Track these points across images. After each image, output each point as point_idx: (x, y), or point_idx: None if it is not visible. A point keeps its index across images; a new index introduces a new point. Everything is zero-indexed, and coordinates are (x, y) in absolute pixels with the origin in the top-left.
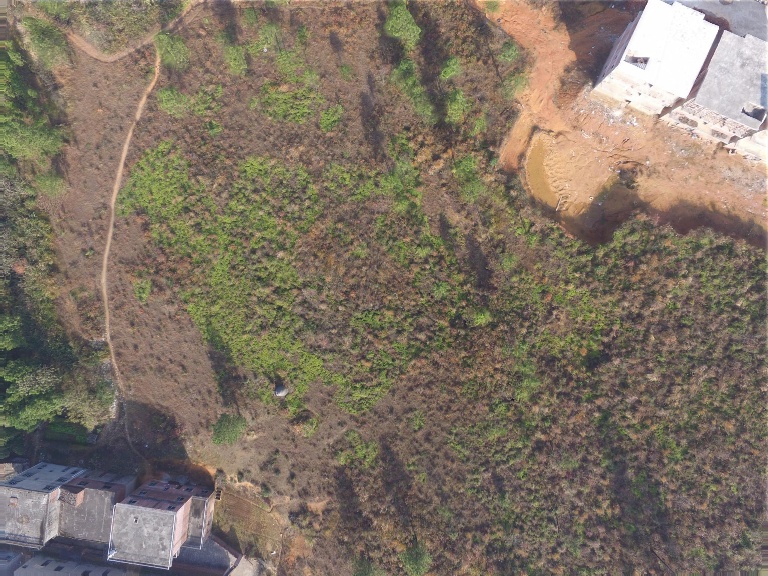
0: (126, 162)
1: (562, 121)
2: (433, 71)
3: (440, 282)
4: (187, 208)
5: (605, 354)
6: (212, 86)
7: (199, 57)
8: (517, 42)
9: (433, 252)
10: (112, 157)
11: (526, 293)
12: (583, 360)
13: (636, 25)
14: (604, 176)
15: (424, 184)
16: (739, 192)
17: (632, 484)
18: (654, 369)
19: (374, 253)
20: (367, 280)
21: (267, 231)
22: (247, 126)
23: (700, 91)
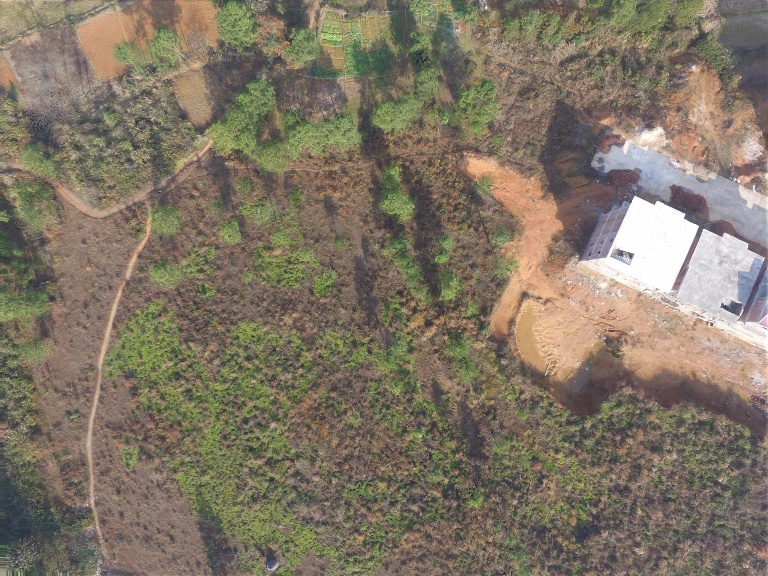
0: (115, 323)
1: (550, 288)
2: (425, 236)
3: (433, 451)
4: (178, 373)
5: (594, 525)
6: (205, 248)
7: (192, 217)
8: (507, 210)
9: (426, 421)
10: (100, 317)
11: (517, 461)
12: (573, 530)
13: (621, 222)
14: (591, 342)
15: (417, 349)
16: (718, 362)
17: None
18: (641, 542)
19: (367, 422)
20: (360, 450)
21: (260, 400)
22: (240, 290)
23: (682, 287)
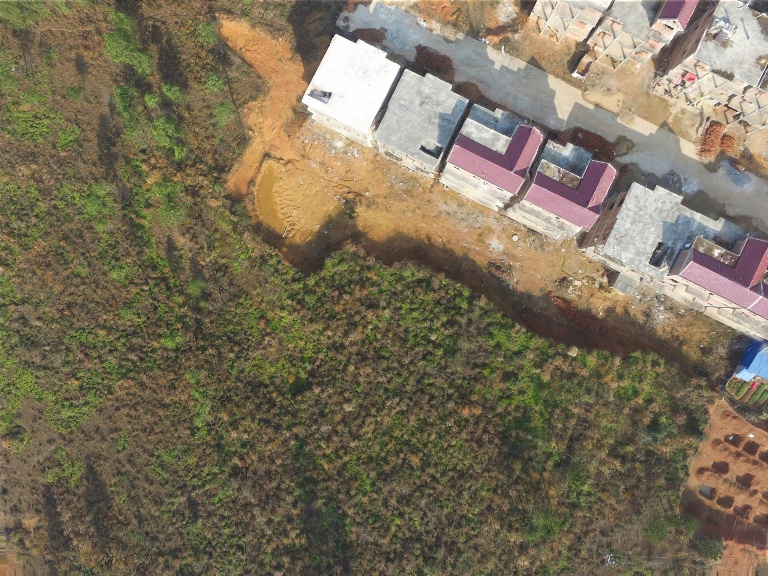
0: None
1: (292, 149)
2: None
3: (158, 303)
4: None
5: (309, 382)
6: None
7: None
8: (254, 71)
9: (152, 273)
10: None
11: (243, 318)
12: (290, 387)
13: None
14: (330, 205)
15: (155, 206)
16: (455, 226)
17: (321, 514)
18: (352, 399)
19: (95, 272)
20: (85, 299)
21: None
22: None
23: (379, 127)
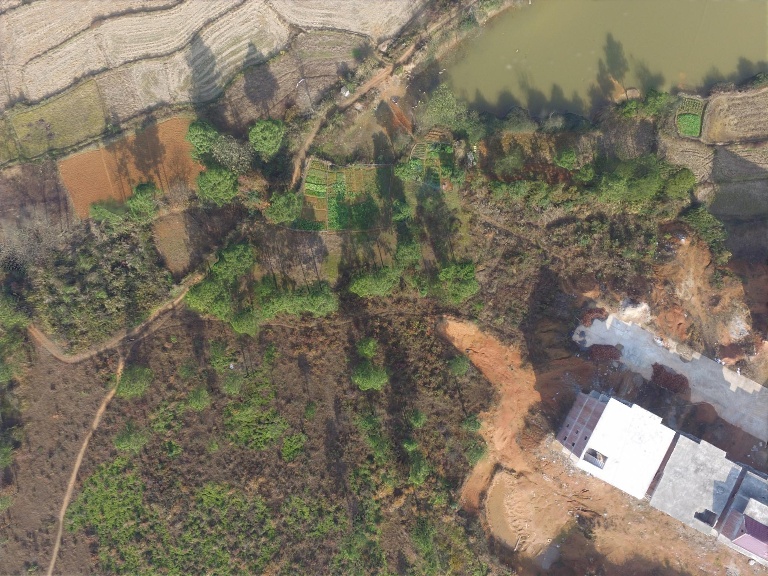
0: (79, 475)
1: (524, 461)
2: (400, 400)
3: None
4: (139, 534)
5: None
6: (174, 403)
7: (163, 369)
8: (484, 377)
9: None
10: (65, 467)
11: None
12: None
13: (596, 424)
14: (563, 519)
15: (384, 518)
16: (692, 549)
17: None
18: None
19: None
20: None
21: (220, 568)
22: (207, 450)
23: (655, 494)
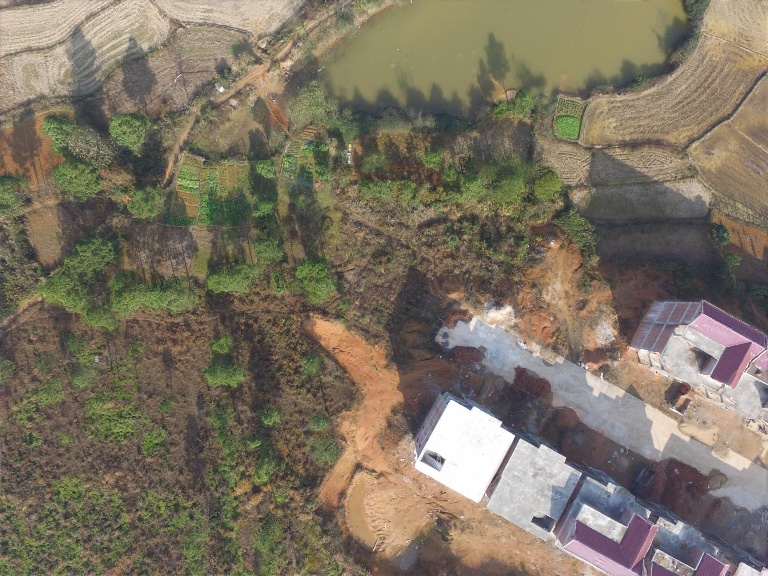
0: None
1: (385, 462)
2: (263, 397)
3: None
4: None
5: None
6: None
7: (28, 361)
8: (348, 376)
9: None
10: None
11: None
12: None
13: (435, 426)
14: (422, 521)
15: (242, 515)
16: (549, 555)
17: None
18: None
19: None
20: None
21: (73, 561)
22: (67, 442)
23: (492, 498)
